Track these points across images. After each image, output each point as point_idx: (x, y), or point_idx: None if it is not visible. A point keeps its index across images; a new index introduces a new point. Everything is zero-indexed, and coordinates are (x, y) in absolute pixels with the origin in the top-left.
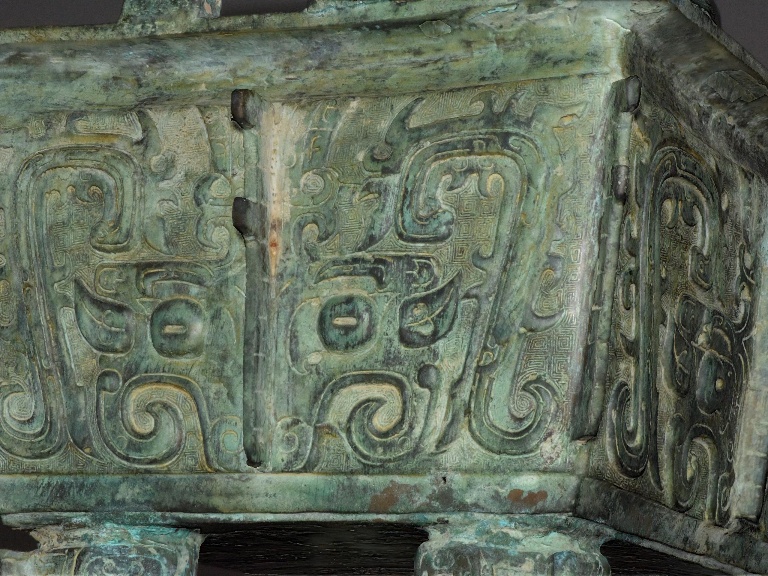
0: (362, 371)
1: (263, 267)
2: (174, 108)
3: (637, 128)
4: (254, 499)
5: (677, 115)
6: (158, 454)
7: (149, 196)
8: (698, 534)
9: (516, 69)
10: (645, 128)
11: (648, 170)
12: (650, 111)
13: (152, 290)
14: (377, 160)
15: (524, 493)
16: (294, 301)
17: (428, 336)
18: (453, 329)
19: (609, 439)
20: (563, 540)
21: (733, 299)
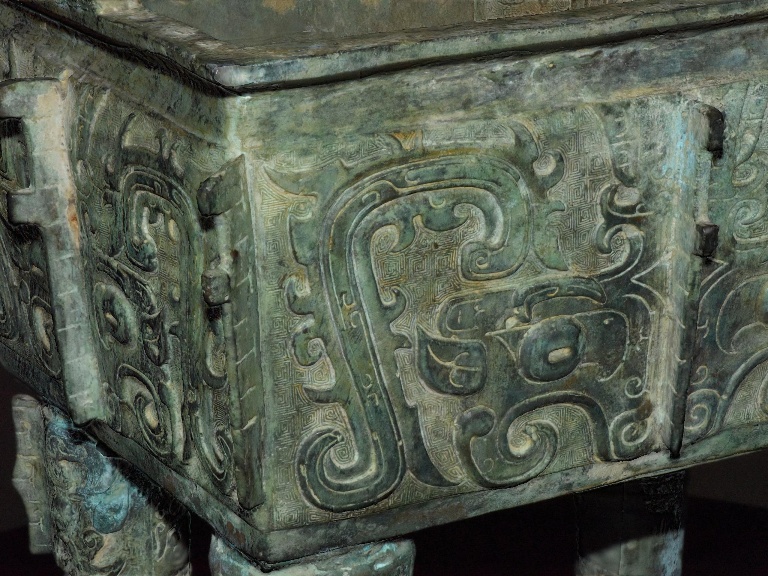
0: (132, 366)
1: (58, 247)
2: (26, 45)
3: (284, 191)
4: (110, 439)
5: (414, 118)
6: (57, 372)
7: (13, 134)
8: (597, 472)
9: (183, 110)
10: (300, 186)
11: (321, 221)
12: (315, 160)
13: (25, 226)
14: (107, 172)
15: (234, 529)
16: (91, 279)
17: (157, 357)
18: (171, 357)
19: (302, 490)
20: (292, 565)
21: (596, 249)
